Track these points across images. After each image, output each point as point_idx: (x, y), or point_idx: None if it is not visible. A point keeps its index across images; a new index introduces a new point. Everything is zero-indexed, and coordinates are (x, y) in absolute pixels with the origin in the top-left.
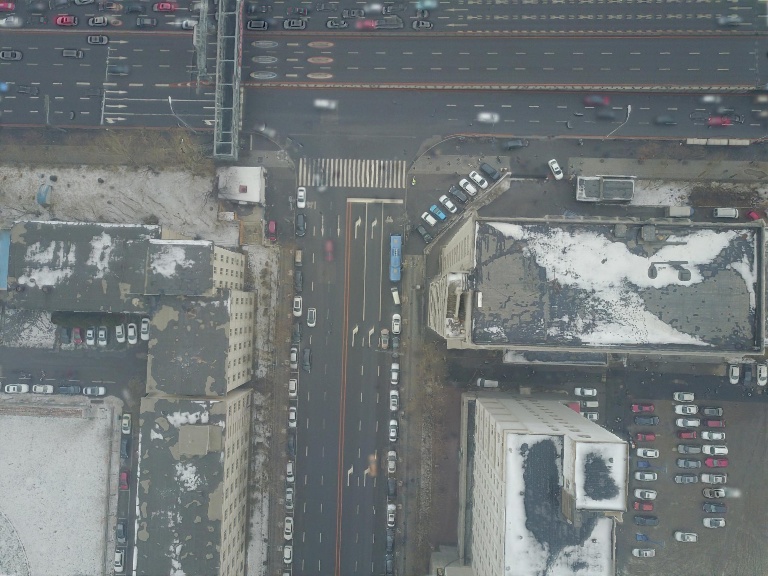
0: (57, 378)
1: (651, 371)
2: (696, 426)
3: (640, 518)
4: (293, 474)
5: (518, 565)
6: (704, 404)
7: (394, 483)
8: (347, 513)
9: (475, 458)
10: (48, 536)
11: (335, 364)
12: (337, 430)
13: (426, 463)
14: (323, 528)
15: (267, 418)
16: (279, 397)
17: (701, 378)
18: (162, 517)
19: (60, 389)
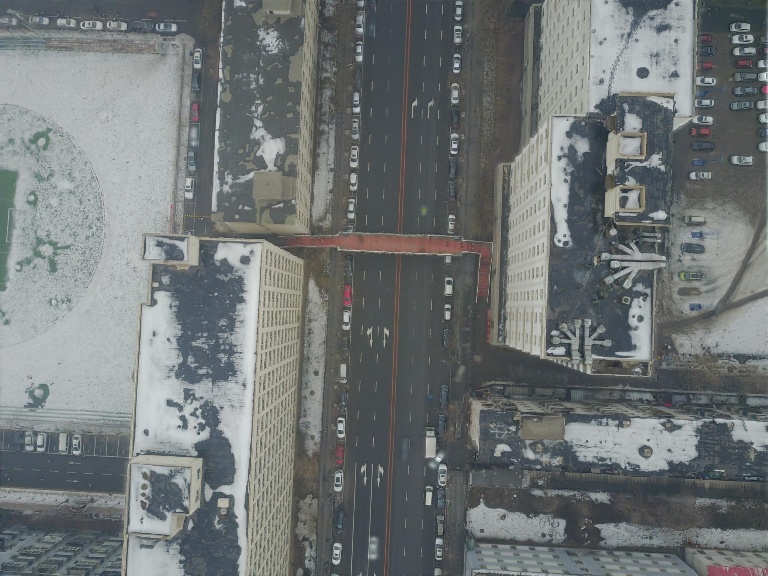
0: (130, 17)
1: (708, 6)
2: (752, 53)
3: (697, 142)
4: (359, 104)
5: (603, 28)
6: (760, 35)
7: (457, 113)
8: (411, 144)
9: (542, 56)
10: (120, 166)
11: (400, 3)
12: (402, 65)
13: (488, 95)
14: (387, 158)
15: (334, 54)
16: (346, 34)
17: (757, 12)
18: (244, 79)
19: (134, 23)
